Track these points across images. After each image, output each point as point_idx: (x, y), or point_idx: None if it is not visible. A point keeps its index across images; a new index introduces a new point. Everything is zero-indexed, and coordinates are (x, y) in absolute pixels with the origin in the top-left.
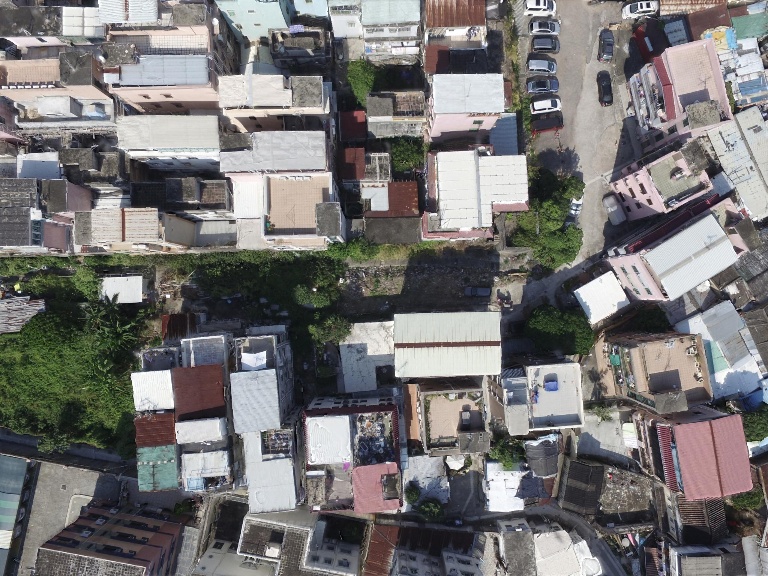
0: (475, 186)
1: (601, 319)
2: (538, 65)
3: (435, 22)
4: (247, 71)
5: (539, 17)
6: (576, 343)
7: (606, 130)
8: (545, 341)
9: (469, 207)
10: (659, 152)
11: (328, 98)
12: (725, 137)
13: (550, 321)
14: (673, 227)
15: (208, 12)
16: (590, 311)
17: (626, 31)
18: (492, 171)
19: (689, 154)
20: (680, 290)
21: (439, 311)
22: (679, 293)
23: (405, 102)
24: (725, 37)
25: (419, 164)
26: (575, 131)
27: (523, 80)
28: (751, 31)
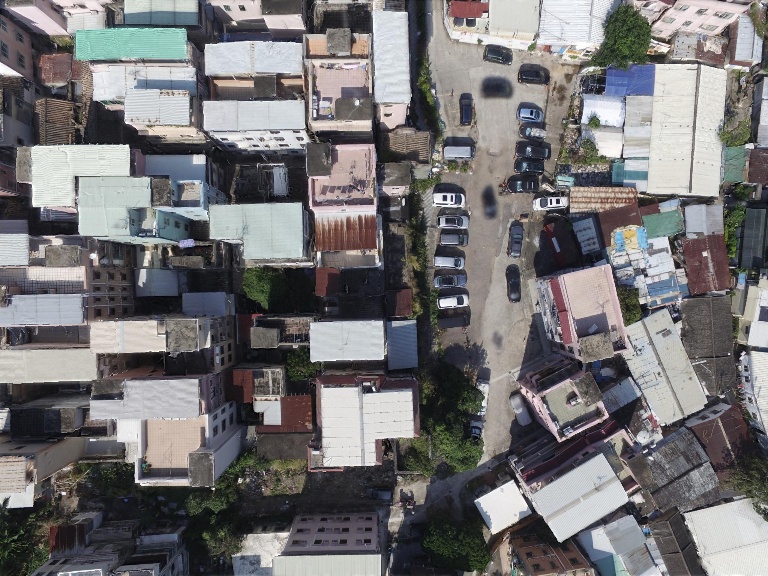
0: (358, 424)
1: (502, 529)
2: (444, 262)
3: (325, 245)
4: (141, 277)
5: (448, 208)
6: (471, 564)
7: (515, 325)
8: (439, 562)
9: (352, 445)
10: (555, 375)
11: (209, 332)
12: (633, 341)
13: (443, 544)
14: (567, 457)
15: (84, 249)
16: (491, 521)
17: (537, 223)
18: (376, 408)
19: (582, 386)
20: (569, 531)
21: (336, 519)
22: (567, 534)
23: (294, 325)
24: (635, 236)
25: (316, 373)
26: (483, 326)
27: (431, 272)
28: (662, 230)
